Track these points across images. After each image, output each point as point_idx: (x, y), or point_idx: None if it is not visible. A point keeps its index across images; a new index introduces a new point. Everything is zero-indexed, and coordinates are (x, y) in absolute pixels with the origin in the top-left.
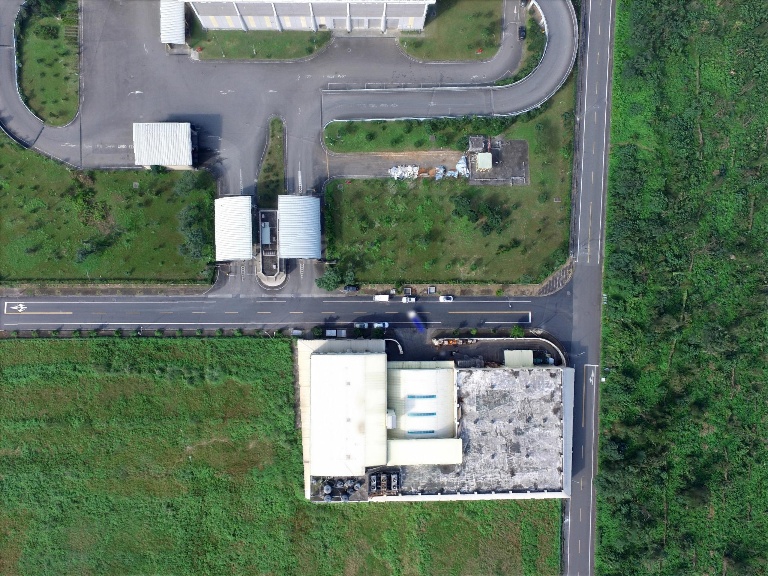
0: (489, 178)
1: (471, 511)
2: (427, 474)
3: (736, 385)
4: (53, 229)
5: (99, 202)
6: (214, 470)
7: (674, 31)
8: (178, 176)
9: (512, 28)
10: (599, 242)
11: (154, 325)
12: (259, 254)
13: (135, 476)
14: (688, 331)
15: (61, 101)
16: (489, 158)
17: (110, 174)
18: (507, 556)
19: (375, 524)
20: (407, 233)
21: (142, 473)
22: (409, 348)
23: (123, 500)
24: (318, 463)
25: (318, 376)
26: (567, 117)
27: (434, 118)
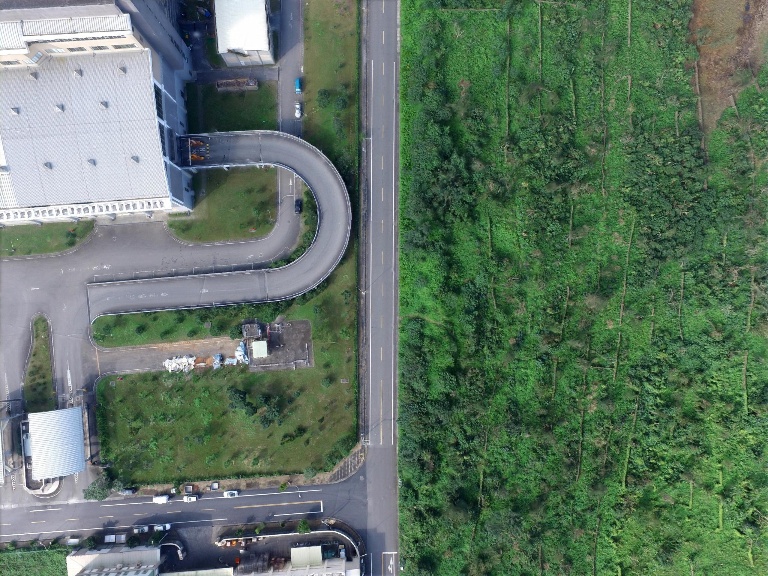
0: (270, 363)
1: None
2: None
3: (544, 564)
4: None
5: None
6: None
7: (455, 198)
8: None
9: (288, 201)
10: (392, 422)
11: None
12: (23, 467)
13: None
14: (488, 512)
15: None
16: (264, 347)
17: None
18: None
19: None
20: (185, 428)
21: None
22: (193, 549)
23: None
24: None
25: None
26: (347, 296)
27: (205, 307)
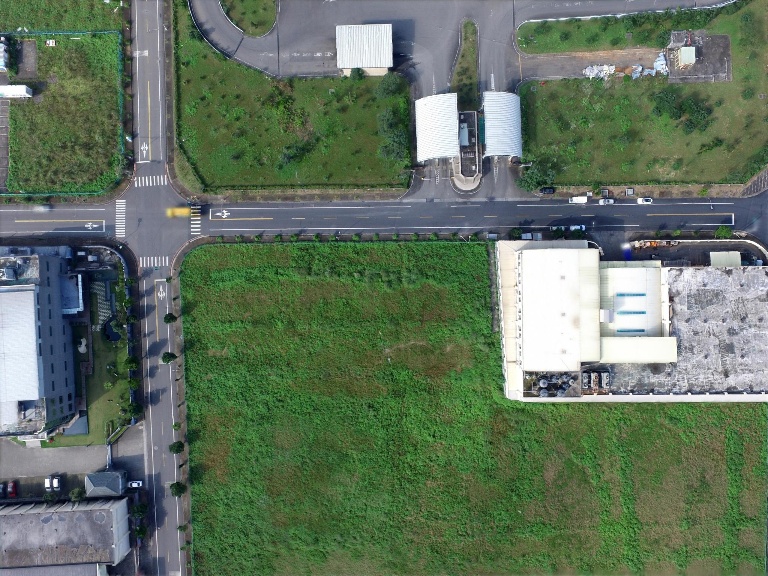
0: (689, 75)
1: (673, 418)
2: (637, 374)
3: None
4: (254, 137)
5: (298, 109)
6: (413, 372)
7: None
8: (372, 82)
9: None
10: None
11: (351, 230)
12: None
13: (337, 377)
14: None
15: (260, 11)
16: (693, 52)
17: (307, 82)
18: (711, 465)
19: (574, 429)
20: (604, 134)
21: (343, 374)
22: (607, 251)
23: (325, 400)
24: (532, 358)
25: (530, 271)
26: None
27: (633, 14)
